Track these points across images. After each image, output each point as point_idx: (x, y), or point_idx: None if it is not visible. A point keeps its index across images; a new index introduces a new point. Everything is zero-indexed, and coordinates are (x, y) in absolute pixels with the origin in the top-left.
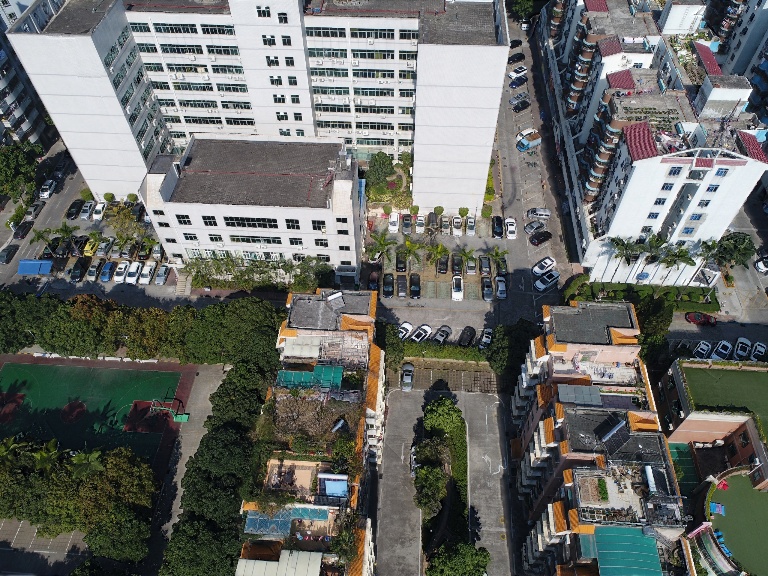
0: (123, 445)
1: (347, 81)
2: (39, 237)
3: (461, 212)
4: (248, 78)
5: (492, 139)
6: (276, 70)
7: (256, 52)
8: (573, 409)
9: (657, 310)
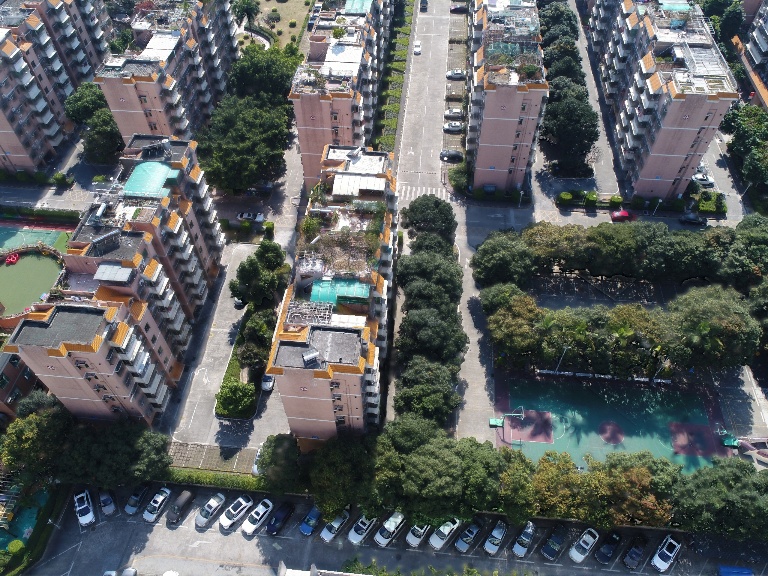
0: (544, 399)
1: None
2: None
3: None
4: None
5: None
6: None
7: None
8: None
9: None
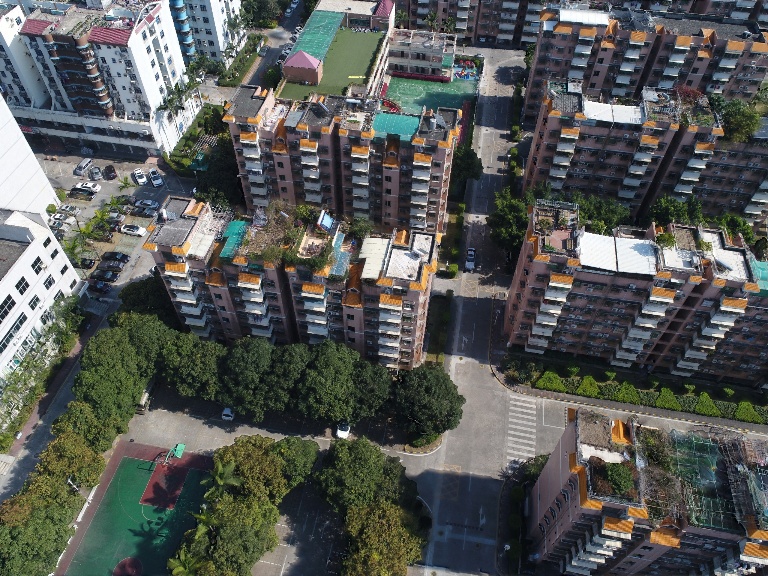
0: (190, 507)
1: None
2: None
3: (52, 209)
4: None
5: (18, 129)
6: None
7: None
8: None
9: (220, 118)
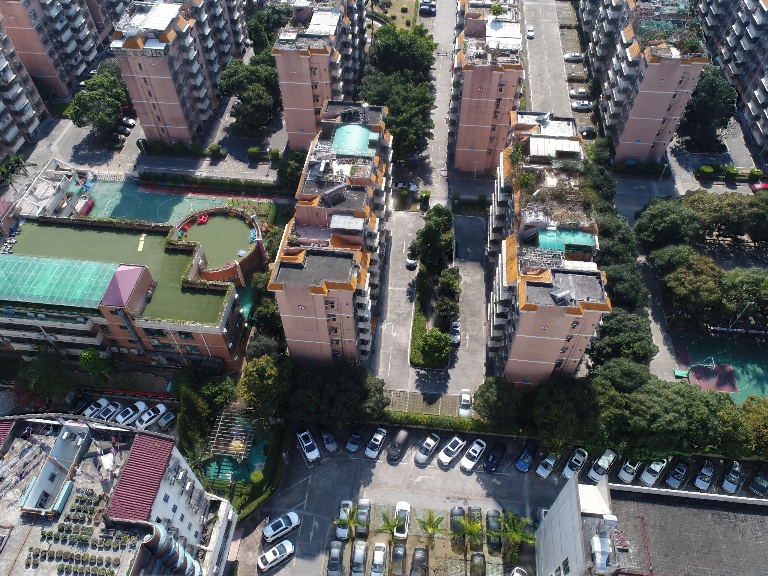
0: (722, 353)
1: None
2: None
3: None
4: None
5: None
6: None
7: None
8: None
9: None
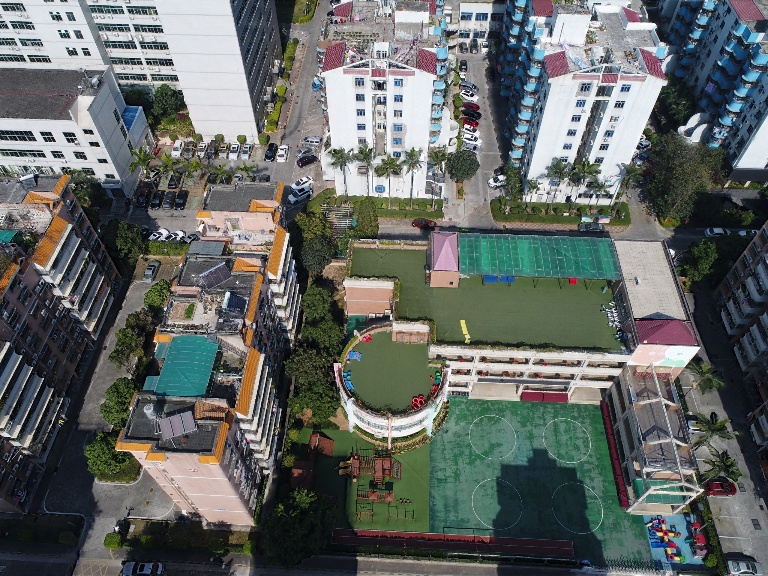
0: None
1: (125, 18)
2: None
3: (238, 139)
4: (30, 14)
5: (242, 66)
6: (53, 6)
7: None
8: (194, 257)
9: None
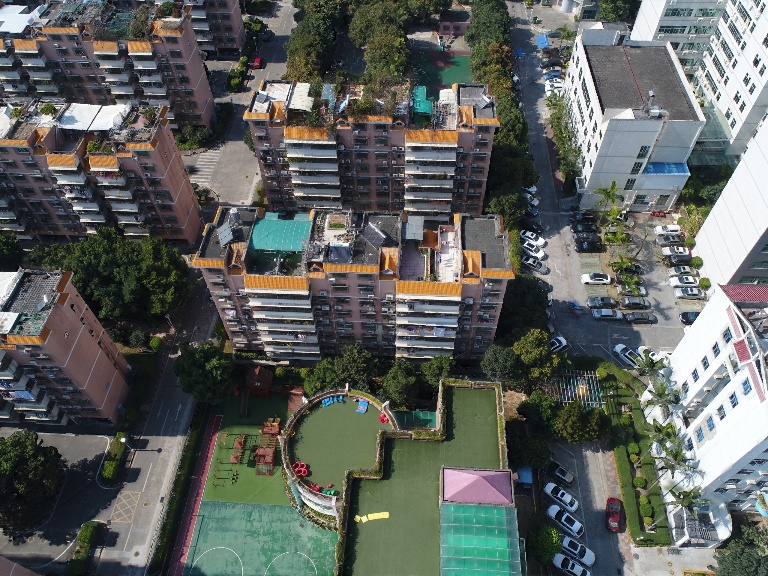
0: None
1: None
2: (561, 29)
3: (701, 278)
4: (749, 44)
5: (765, 229)
6: (763, 51)
7: (767, 24)
8: None
9: (585, 415)
